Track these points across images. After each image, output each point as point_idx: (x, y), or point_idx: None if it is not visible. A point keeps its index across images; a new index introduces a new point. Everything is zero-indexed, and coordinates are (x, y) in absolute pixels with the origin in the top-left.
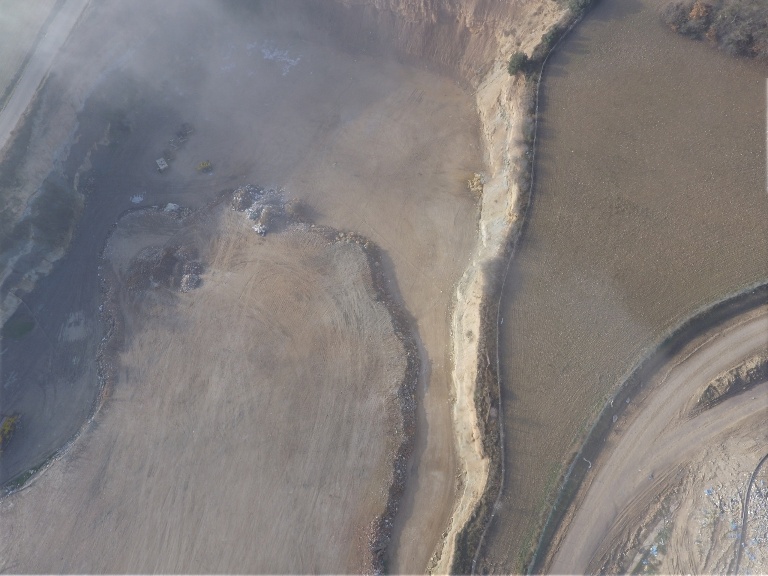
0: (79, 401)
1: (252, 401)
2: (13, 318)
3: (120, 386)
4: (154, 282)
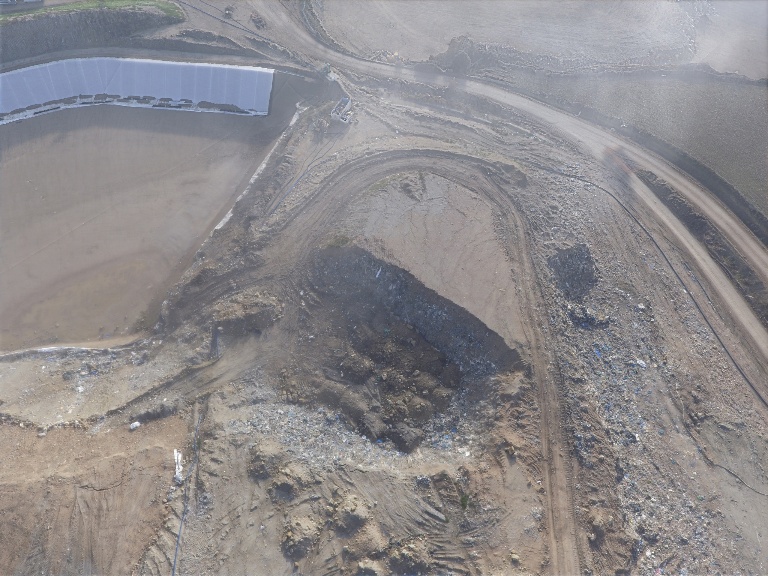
0: None
1: (564, 2)
2: None
3: None
4: None
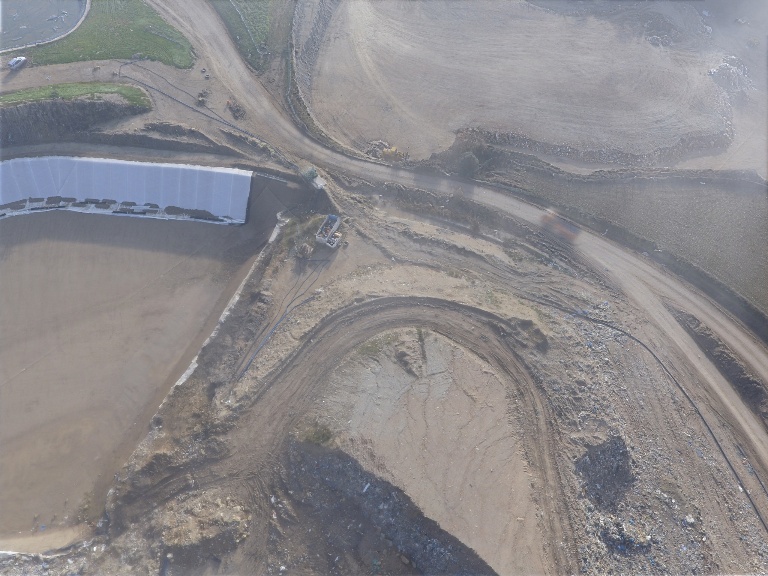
0: (557, 7)
1: (583, 76)
2: None
3: (574, 18)
4: (647, 24)
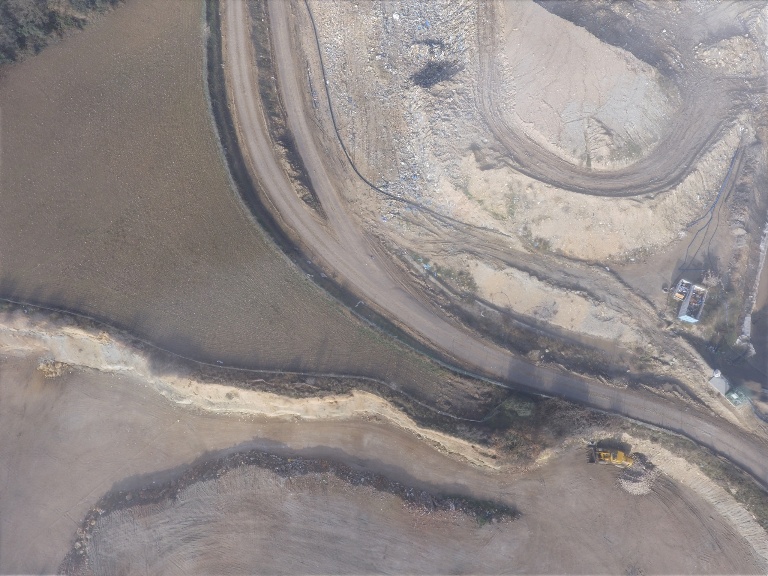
0: None
1: None
2: None
3: None
4: None
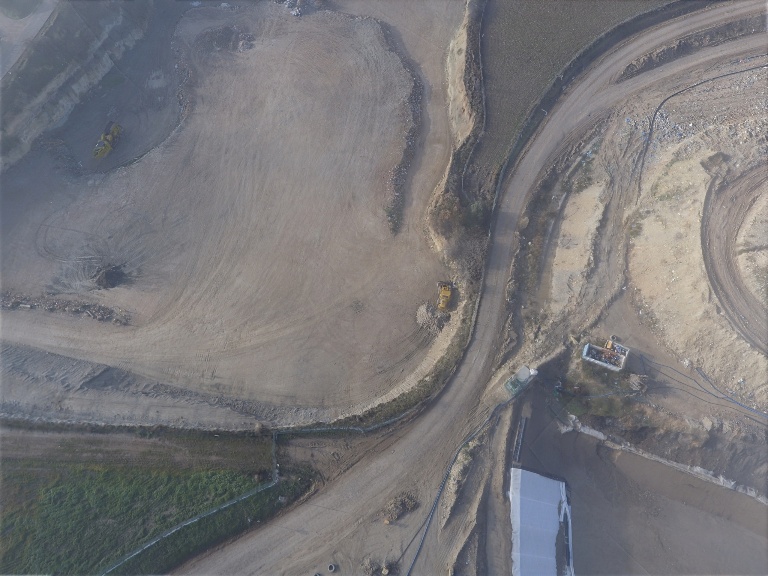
0: (166, 120)
1: (299, 109)
2: (109, 74)
3: (198, 106)
4: (217, 47)
